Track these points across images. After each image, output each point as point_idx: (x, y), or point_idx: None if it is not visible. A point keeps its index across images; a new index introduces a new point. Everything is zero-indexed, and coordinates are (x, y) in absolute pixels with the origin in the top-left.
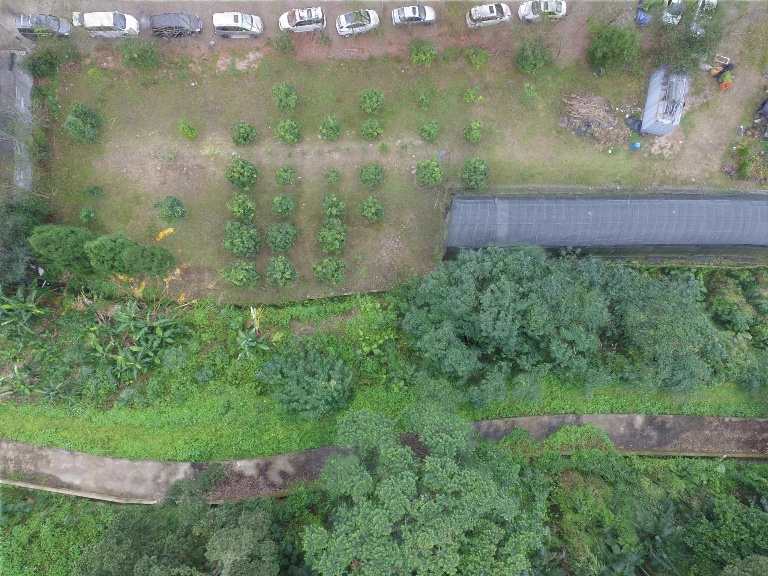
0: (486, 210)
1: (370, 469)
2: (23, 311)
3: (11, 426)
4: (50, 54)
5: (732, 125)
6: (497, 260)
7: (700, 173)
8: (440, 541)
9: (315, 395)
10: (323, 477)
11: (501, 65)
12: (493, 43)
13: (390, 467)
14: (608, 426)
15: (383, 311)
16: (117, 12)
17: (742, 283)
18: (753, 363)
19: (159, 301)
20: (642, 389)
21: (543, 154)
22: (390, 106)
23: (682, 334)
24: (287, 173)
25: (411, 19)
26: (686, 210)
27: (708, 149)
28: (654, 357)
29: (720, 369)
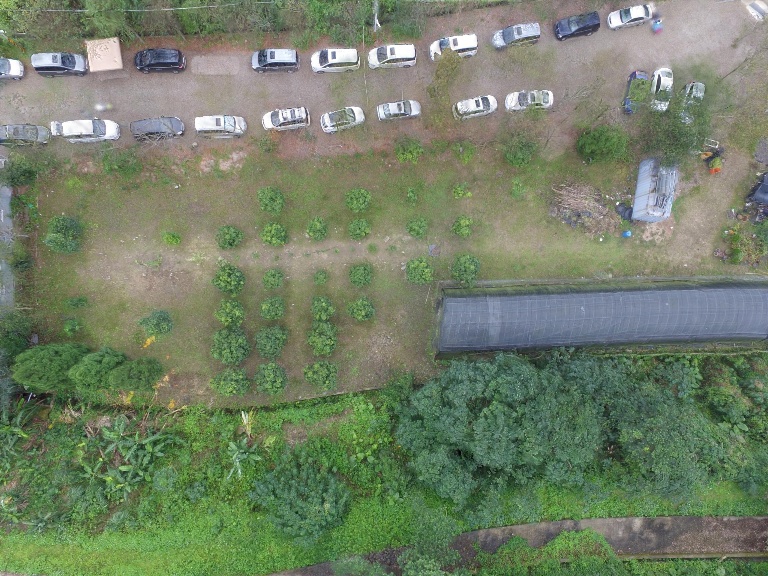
0: (478, 309)
1: None
2: (9, 435)
3: None
4: (29, 162)
5: (723, 209)
6: (490, 378)
7: (692, 258)
8: None
9: (309, 521)
10: None
11: (489, 156)
12: (480, 134)
13: None
14: (606, 530)
15: (376, 412)
16: (96, 118)
17: (737, 369)
18: (750, 462)
19: (148, 409)
20: (639, 494)
21: (534, 245)
22: (378, 202)
23: (678, 438)
24: (275, 278)
25: (397, 115)
26: (679, 302)
27: (700, 234)
28: (651, 468)
29: (717, 469)
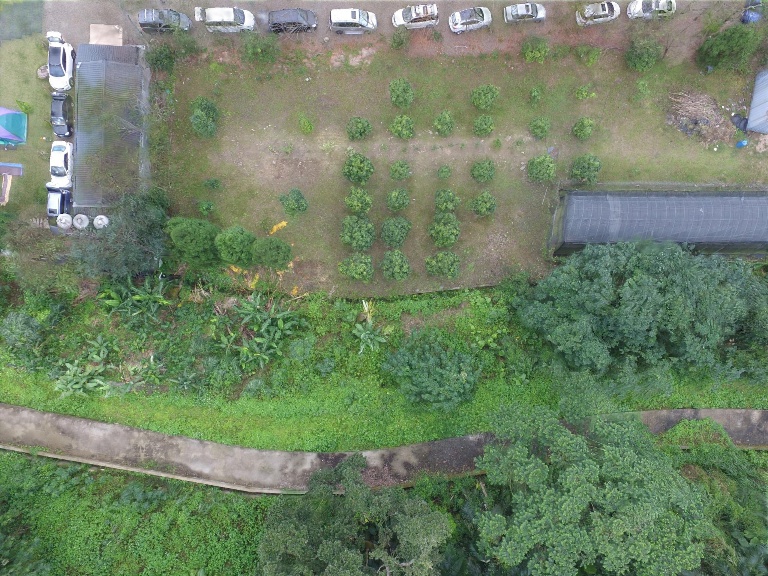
0: (599, 206)
1: (492, 461)
2: (150, 302)
3: (141, 415)
4: (168, 49)
5: None
6: (629, 255)
7: None
8: (631, 528)
9: (448, 387)
10: (446, 469)
11: (609, 63)
12: (601, 41)
13: (565, 456)
14: (726, 421)
15: (494, 305)
16: (236, 8)
17: None
18: None
19: (273, 294)
20: (762, 384)
21: (649, 151)
22: (500, 103)
23: None
24: (403, 168)
25: (524, 16)
26: None
27: None
28: None
29: None
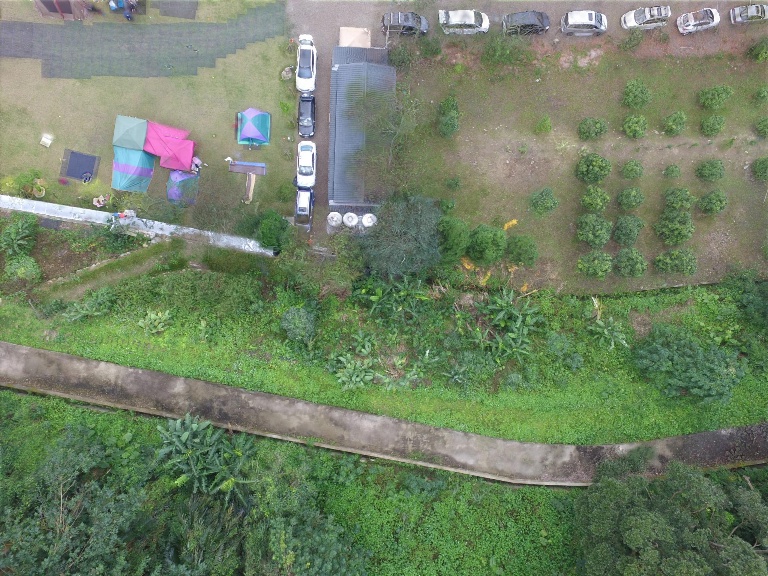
0: None
1: (745, 455)
2: (409, 298)
3: (407, 408)
4: (406, 51)
5: None
6: None
7: None
8: None
9: (720, 382)
10: (699, 462)
11: None
12: None
13: None
14: None
15: (721, 303)
16: (474, 10)
17: None
18: None
19: None
20: None
21: None
22: None
23: None
24: (640, 167)
25: (752, 18)
26: None
27: None
28: None
29: None
